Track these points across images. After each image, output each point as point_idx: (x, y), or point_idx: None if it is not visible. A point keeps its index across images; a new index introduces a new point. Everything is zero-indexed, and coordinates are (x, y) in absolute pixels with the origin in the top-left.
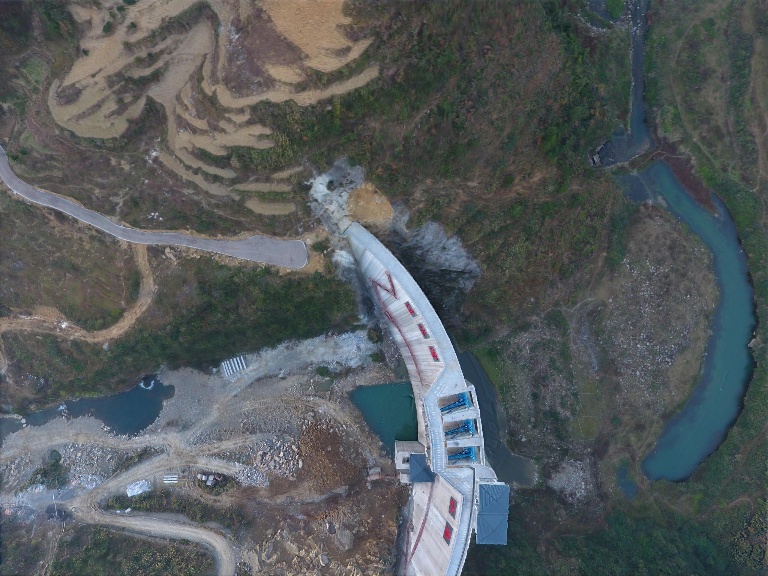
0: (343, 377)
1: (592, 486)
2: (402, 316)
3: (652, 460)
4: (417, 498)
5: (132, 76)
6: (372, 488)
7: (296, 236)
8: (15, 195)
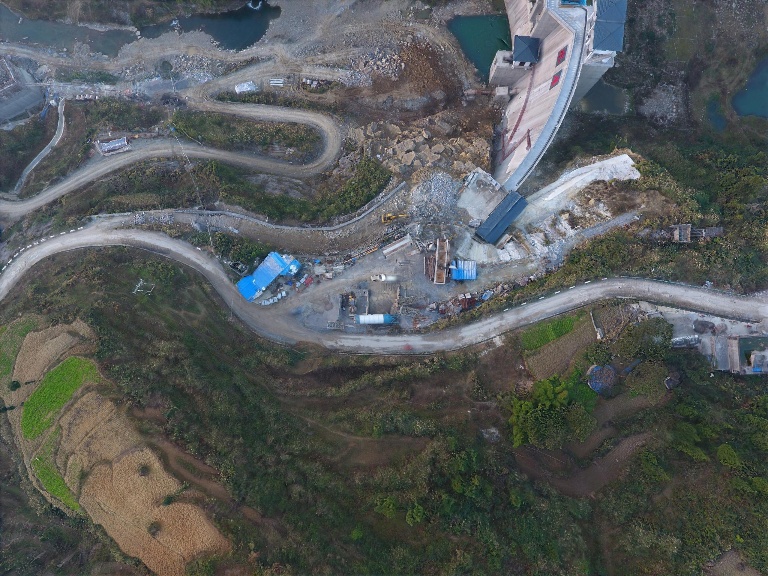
0: (442, 5)
1: (683, 110)
2: None
3: (742, 98)
4: (512, 110)
5: None
6: (467, 106)
7: None
8: None
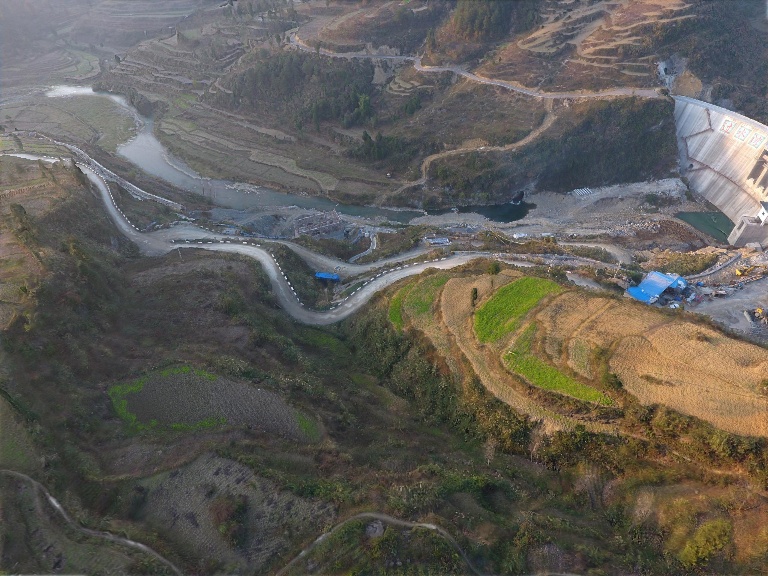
0: (666, 206)
1: None
2: (714, 149)
3: None
4: None
5: (563, 34)
6: None
7: (649, 87)
8: (482, 82)
